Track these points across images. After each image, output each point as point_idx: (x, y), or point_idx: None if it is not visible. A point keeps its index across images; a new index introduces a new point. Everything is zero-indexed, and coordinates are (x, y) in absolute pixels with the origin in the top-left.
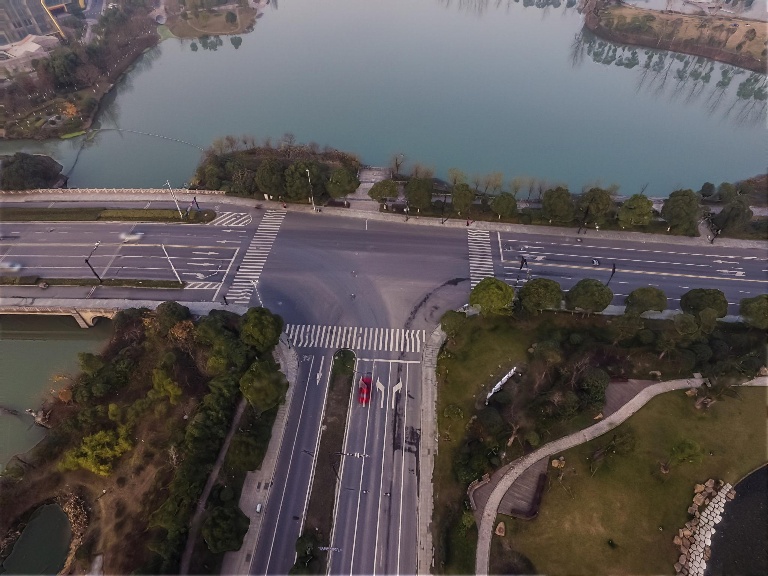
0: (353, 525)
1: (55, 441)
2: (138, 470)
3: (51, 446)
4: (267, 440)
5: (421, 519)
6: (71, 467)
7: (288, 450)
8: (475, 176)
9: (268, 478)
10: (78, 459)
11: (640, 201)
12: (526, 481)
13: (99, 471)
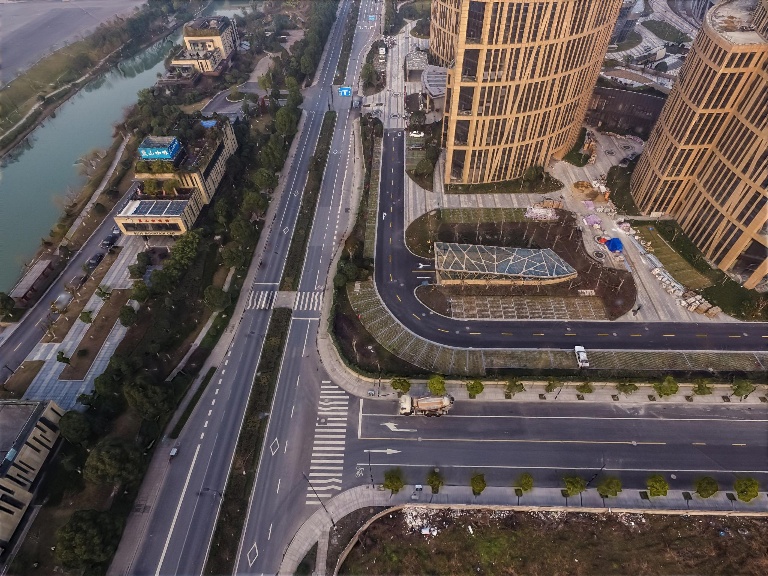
0: (365, 8)
1: (278, 2)
2: (304, 6)
3: (277, 3)
4: (339, 2)
5: (383, 7)
6: (285, 5)
7: (345, 3)
8: None
9: (341, 5)
10: (286, 4)
11: None
12: (411, 1)
13: (293, 5)
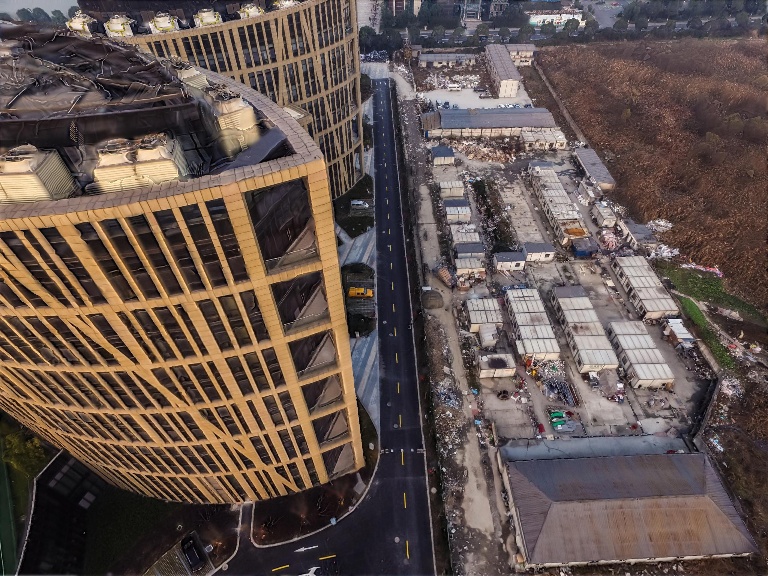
0: None
1: None
2: None
3: None
4: None
5: None
6: None
7: None
8: (14, 14)
9: None
10: None
11: (54, 11)
12: None
13: None
